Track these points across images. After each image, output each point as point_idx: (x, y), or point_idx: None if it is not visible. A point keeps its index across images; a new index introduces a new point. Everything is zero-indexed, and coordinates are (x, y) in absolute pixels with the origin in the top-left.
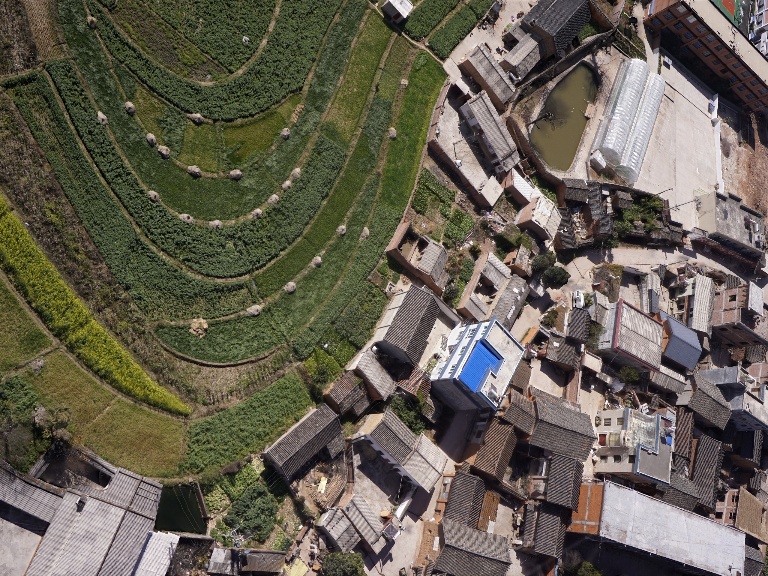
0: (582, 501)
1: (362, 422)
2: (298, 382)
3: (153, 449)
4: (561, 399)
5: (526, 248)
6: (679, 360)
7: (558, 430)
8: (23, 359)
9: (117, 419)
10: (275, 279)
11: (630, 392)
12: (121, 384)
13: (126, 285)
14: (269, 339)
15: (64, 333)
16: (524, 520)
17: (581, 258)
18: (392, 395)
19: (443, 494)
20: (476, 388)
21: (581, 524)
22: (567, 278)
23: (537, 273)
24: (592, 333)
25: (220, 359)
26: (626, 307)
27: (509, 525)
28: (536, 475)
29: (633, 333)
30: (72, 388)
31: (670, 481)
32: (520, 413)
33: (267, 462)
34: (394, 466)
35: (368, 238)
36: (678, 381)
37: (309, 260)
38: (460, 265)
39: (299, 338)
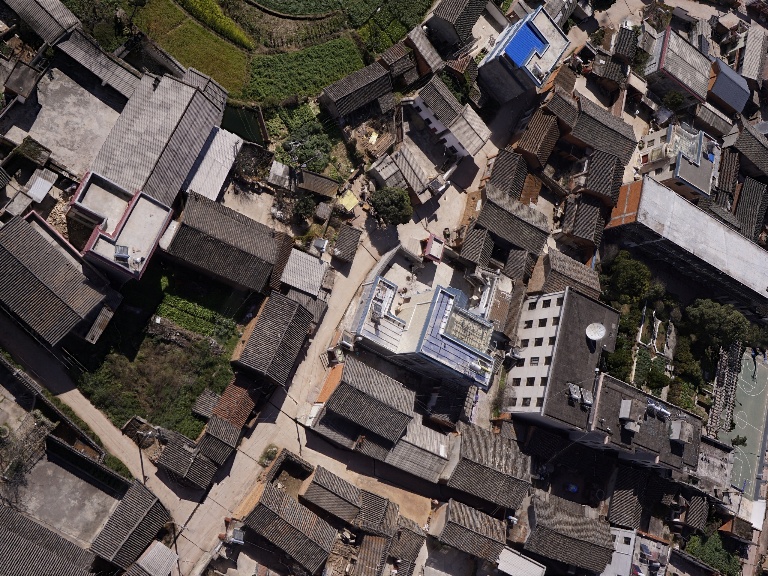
0: (622, 199)
1: (411, 94)
2: (352, 46)
3: (220, 71)
4: (605, 110)
5: None
6: (726, 99)
7: (600, 127)
8: None
9: (188, 37)
10: None
11: None
12: (192, 4)
13: None
14: (326, 3)
15: None
16: (564, 213)
17: None
18: (440, 73)
19: (487, 172)
20: (521, 63)
21: (620, 218)
22: None
23: None
24: (639, 60)
25: (281, 10)
26: (674, 34)
27: (550, 218)
28: (578, 173)
29: (680, 59)
30: None
31: None
32: (563, 105)
33: (323, 105)
34: (441, 137)
35: None
36: (724, 121)
37: None
38: None
39: (354, 7)
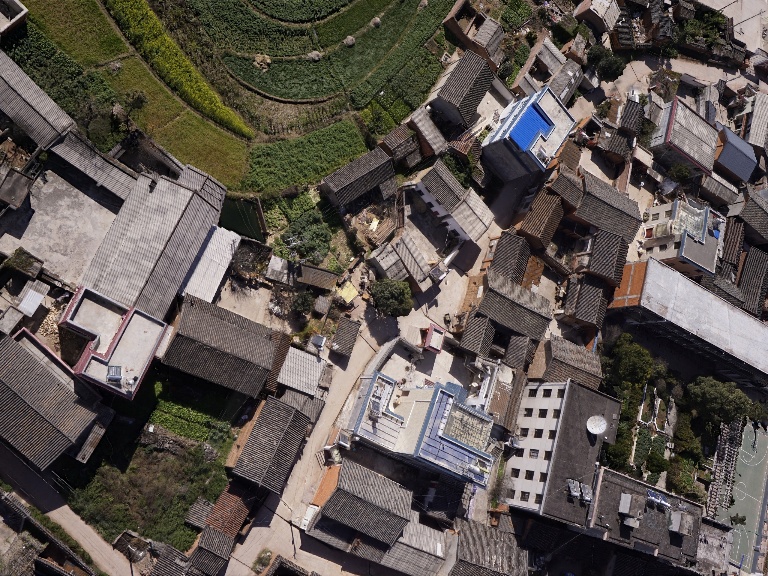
0: (625, 279)
1: (414, 176)
2: (354, 129)
3: (218, 162)
4: (610, 185)
5: (583, 37)
6: (733, 169)
7: (605, 207)
8: (102, 59)
9: (186, 129)
10: (335, 32)
11: (680, 195)
12: (190, 96)
13: (196, 11)
14: (328, 85)
15: (139, 42)
16: (567, 292)
17: (638, 62)
18: (444, 154)
19: (489, 254)
20: (526, 147)
21: (623, 299)
22: (622, 69)
23: (592, 63)
24: (645, 131)
25: (281, 94)
26: (681, 106)
27: (552, 297)
28: (581, 252)
29: (687, 131)
30: (146, 93)
31: (715, 280)
32: (568, 185)
33: (323, 193)
34: (443, 220)
35: (426, 8)
36: (730, 190)
37: (368, 20)
38: (516, 49)
39: (356, 88)
